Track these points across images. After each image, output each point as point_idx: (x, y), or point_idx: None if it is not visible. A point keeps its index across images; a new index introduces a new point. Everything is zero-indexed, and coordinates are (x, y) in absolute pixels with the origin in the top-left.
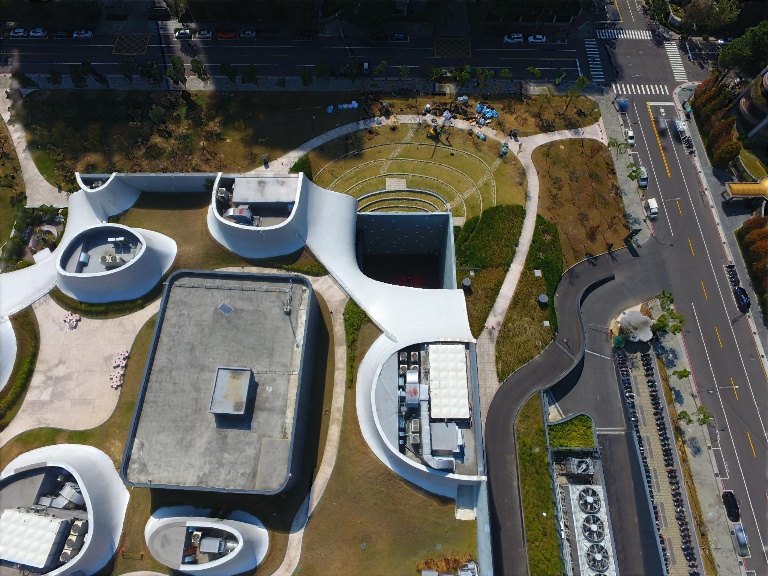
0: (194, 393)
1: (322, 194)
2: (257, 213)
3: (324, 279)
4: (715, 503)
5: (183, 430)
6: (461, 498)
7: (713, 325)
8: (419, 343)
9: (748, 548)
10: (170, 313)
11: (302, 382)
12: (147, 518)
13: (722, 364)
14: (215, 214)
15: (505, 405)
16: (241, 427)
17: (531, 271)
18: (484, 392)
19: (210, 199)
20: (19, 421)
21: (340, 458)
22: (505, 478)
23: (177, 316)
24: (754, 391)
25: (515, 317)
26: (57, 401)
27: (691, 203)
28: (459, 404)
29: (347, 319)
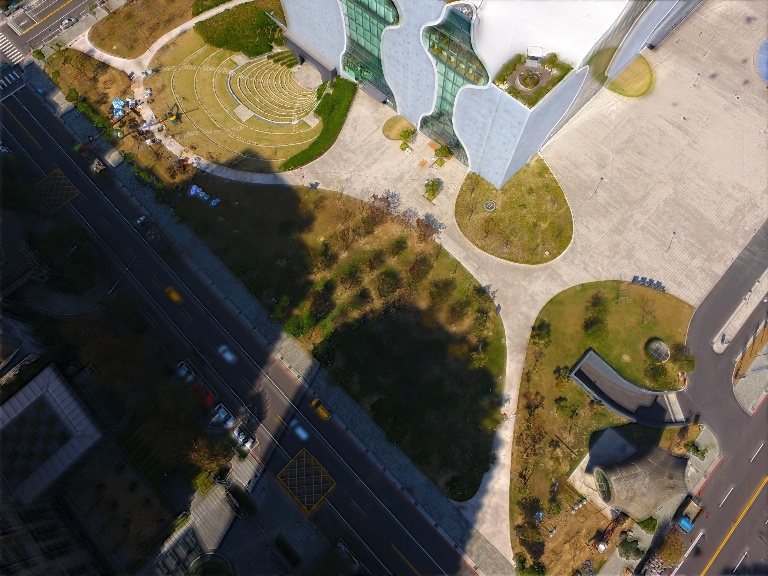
0: None
1: None
2: None
3: None
4: None
5: None
6: None
7: None
8: None
9: None
10: None
11: None
12: None
13: None
14: None
15: None
16: None
17: None
18: None
19: None
20: None
21: None
22: None
23: None
24: None
25: None
26: None
27: None
28: None
29: None
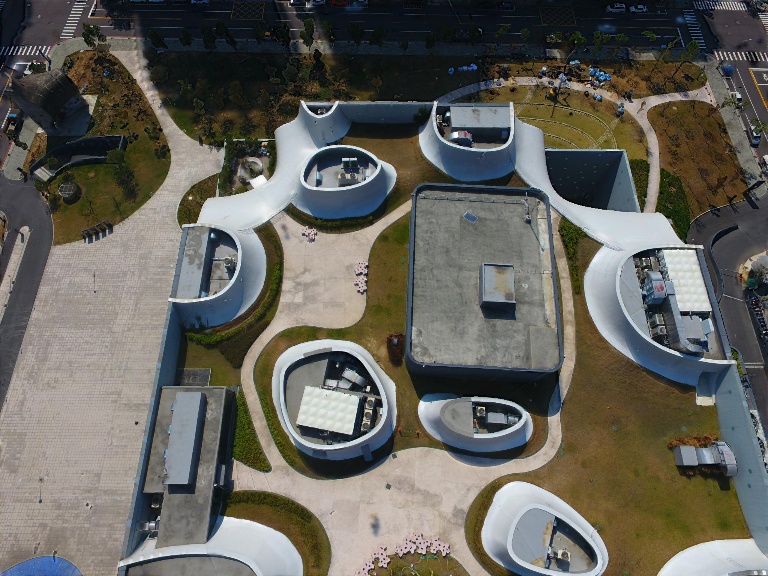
0: (457, 289)
1: (521, 126)
2: None
3: None
4: None
5: (454, 320)
6: (698, 387)
7: None
8: (651, 249)
9: None
10: (420, 221)
11: None
12: (417, 402)
13: None
14: (439, 137)
15: None
16: (507, 317)
17: None
18: None
19: (418, 129)
20: (279, 320)
21: (580, 354)
22: None
23: (427, 223)
24: None
25: None
26: (310, 304)
27: None
28: (700, 299)
29: (566, 234)
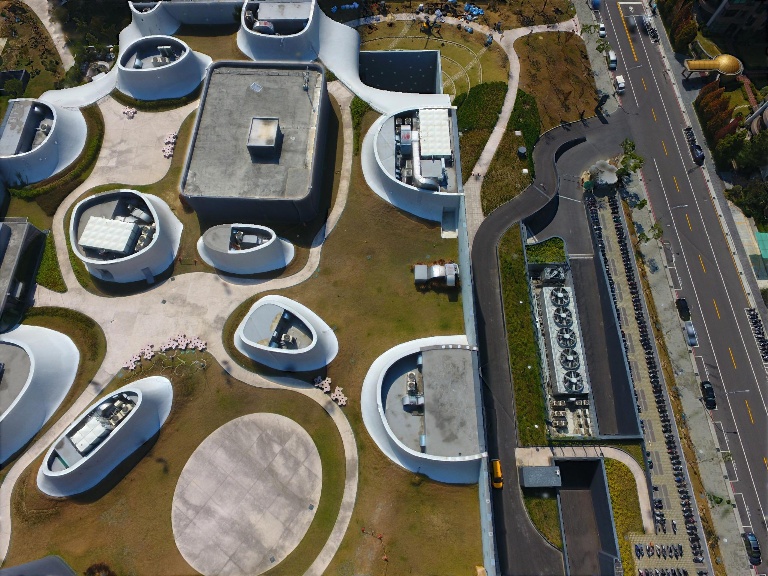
0: (234, 141)
1: (331, 23)
2: (278, 32)
3: (334, 83)
4: (669, 307)
5: (226, 165)
6: (446, 224)
7: (672, 175)
8: (411, 110)
9: (697, 340)
10: (212, 90)
11: (318, 134)
12: (198, 238)
13: (679, 204)
14: (244, 27)
15: (489, 233)
16: (271, 162)
17: (512, 132)
18: (471, 223)
19: (238, 27)
20: (92, 179)
21: (349, 201)
22: (489, 287)
23: (217, 92)
24: (706, 224)
25: (498, 166)
26: (121, 166)
27: (655, 81)
28: (443, 146)
29: (353, 108)
